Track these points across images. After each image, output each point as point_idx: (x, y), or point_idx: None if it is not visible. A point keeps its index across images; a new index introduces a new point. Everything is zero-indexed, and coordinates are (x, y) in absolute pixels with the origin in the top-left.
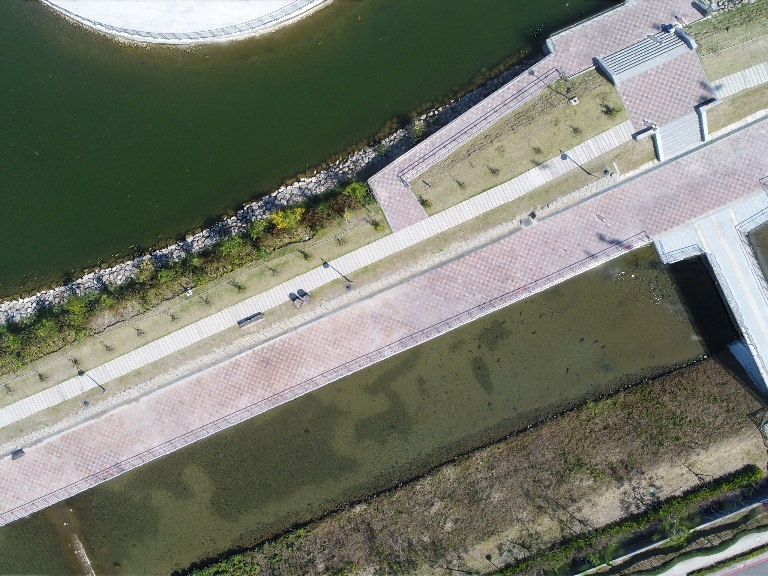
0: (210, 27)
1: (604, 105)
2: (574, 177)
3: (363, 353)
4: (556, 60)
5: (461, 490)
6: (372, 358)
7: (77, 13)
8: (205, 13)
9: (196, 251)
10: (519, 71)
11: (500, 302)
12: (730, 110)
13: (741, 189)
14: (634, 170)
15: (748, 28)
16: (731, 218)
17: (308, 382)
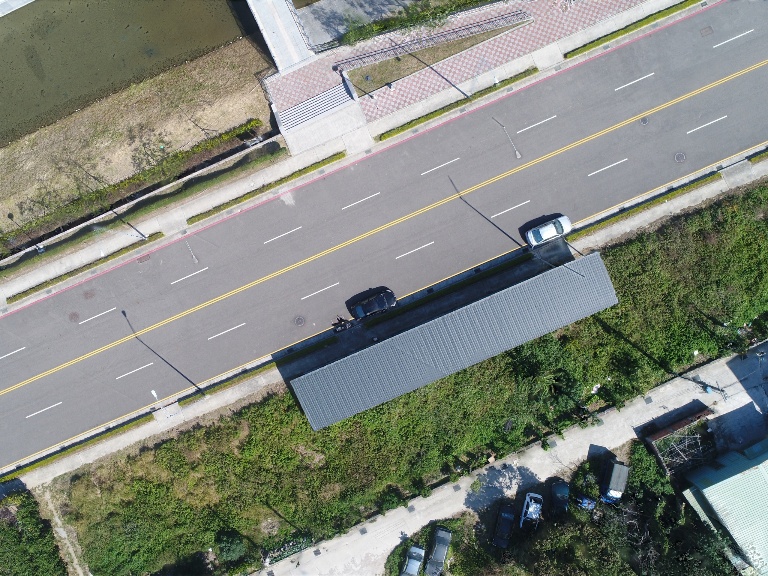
0: None
1: None
2: None
3: None
4: None
5: (3, 166)
6: None
7: None
8: None
9: None
10: None
11: None
12: None
13: None
14: None
15: None
16: None
17: None
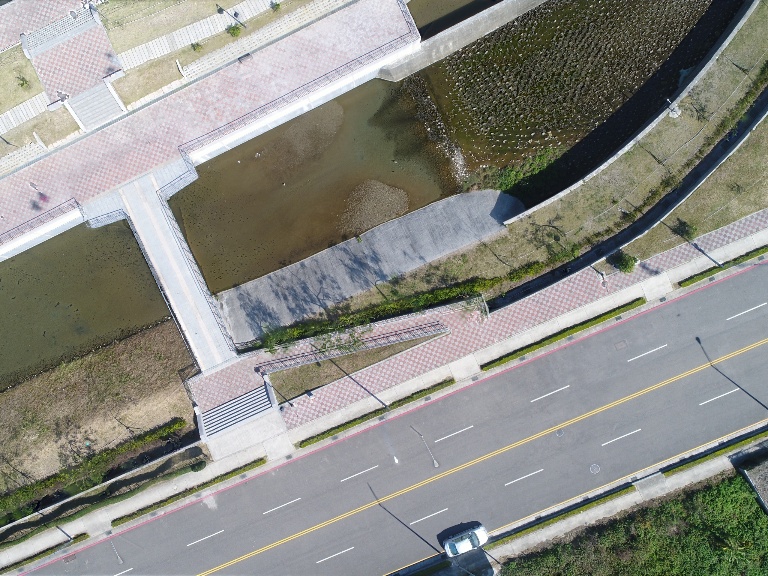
0: None
1: (21, 78)
2: None
3: None
4: None
5: None
6: None
7: None
8: None
9: None
10: None
11: None
12: (142, 81)
13: (161, 156)
14: (61, 140)
15: (151, 2)
16: (152, 184)
17: None
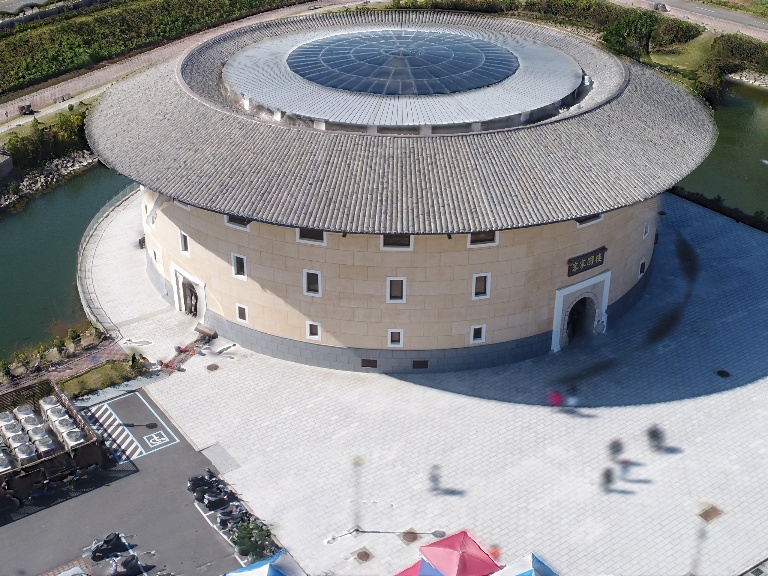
0: None
1: None
2: None
3: None
4: None
5: None
6: None
7: None
8: None
9: None
10: None
11: None
12: None
13: None
14: None
15: None
16: None
17: (1, 108)
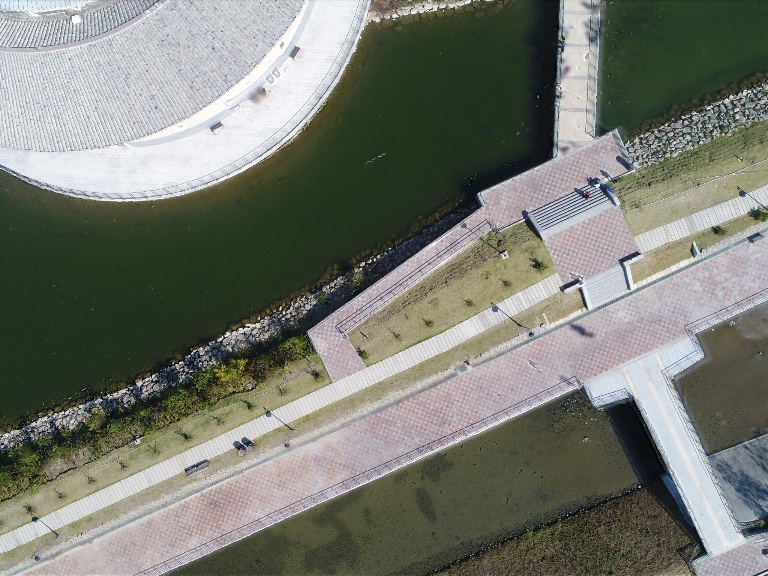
0: (153, 187)
1: (533, 259)
2: (505, 328)
3: (307, 495)
4: (487, 213)
5: None
6: (316, 499)
7: (24, 174)
8: (148, 174)
9: (145, 397)
10: (454, 220)
11: (438, 445)
12: (654, 261)
13: (667, 335)
14: (564, 318)
15: (669, 184)
16: (657, 363)
17: (255, 523)
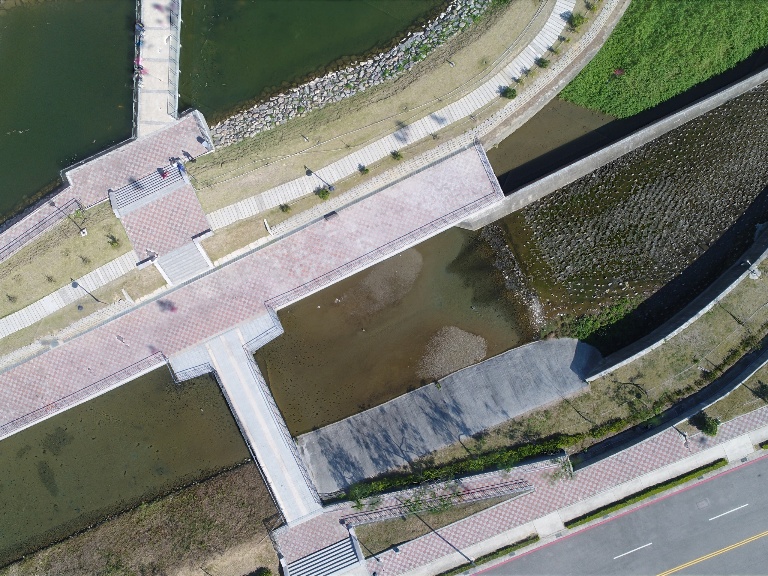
0: None
1: (110, 236)
2: (84, 304)
3: None
4: (75, 192)
5: None
6: None
7: None
8: None
9: None
10: None
11: (32, 418)
12: (230, 239)
13: (247, 311)
14: (148, 294)
15: (240, 163)
16: (239, 338)
17: None
